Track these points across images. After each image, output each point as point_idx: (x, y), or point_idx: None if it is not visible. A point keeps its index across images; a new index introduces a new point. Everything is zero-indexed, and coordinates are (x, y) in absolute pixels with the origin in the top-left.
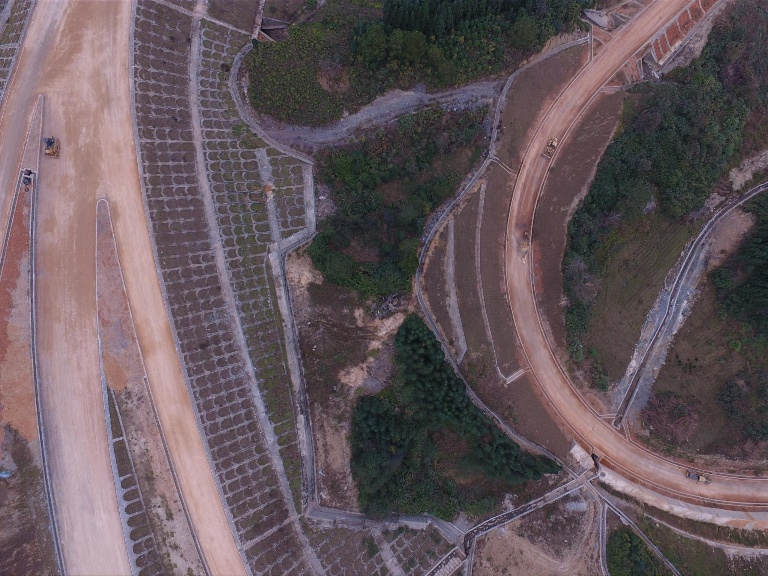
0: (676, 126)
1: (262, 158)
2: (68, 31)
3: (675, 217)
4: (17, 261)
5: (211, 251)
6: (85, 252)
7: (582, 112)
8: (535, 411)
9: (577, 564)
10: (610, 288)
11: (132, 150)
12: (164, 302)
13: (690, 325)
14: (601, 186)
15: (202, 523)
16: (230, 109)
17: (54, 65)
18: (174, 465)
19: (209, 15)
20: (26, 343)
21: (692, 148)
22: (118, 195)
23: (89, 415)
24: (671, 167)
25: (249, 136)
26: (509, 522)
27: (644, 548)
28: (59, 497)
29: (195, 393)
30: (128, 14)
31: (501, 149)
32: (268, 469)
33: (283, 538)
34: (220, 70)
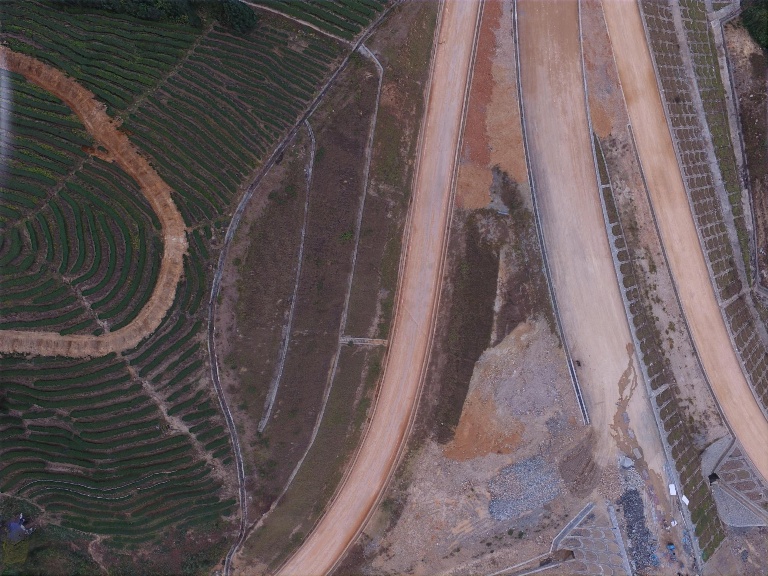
0: None
1: None
2: None
3: None
4: None
5: (669, 8)
6: None
7: None
8: None
9: None
10: None
11: None
12: (649, 47)
13: None
14: None
15: (682, 278)
16: None
17: None
18: (656, 217)
19: None
20: (512, 84)
21: None
22: None
23: (576, 160)
24: None
25: None
26: None
27: None
28: (549, 241)
29: (678, 144)
30: None
31: None
32: (726, 237)
33: (742, 307)
34: None
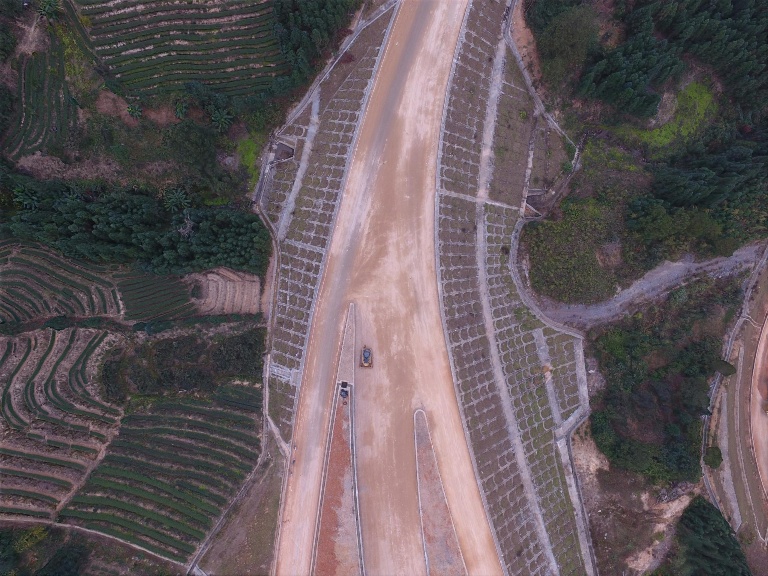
0: None
1: (539, 338)
2: (373, 234)
3: None
4: (340, 478)
5: (512, 448)
6: (405, 465)
7: None
8: None
9: None
10: None
11: (444, 357)
12: (486, 515)
13: None
14: None
15: None
16: (512, 293)
17: (362, 270)
18: None
19: (490, 199)
20: (354, 563)
21: None
22: (433, 404)
23: None
24: None
25: (529, 319)
26: None
27: None
28: None
29: None
30: (431, 214)
31: (754, 308)
32: None
33: None
34: (501, 253)
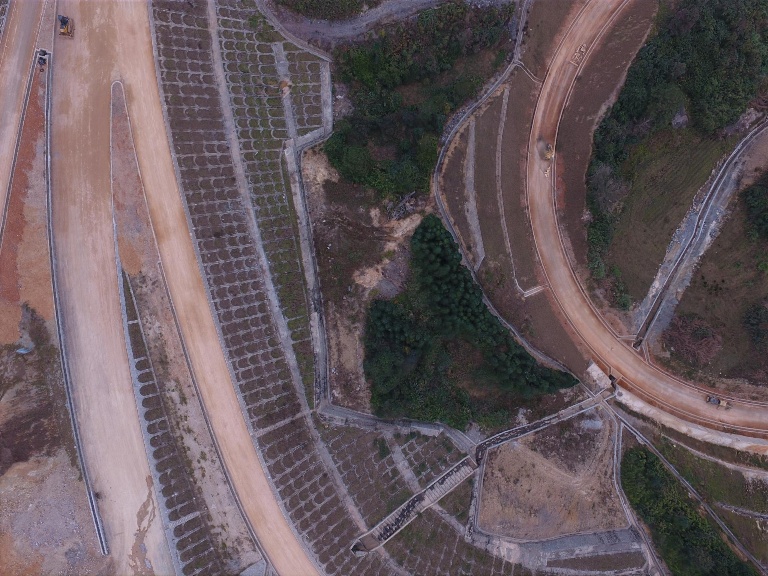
0: (714, 29)
1: (279, 52)
2: None
3: (708, 131)
4: (33, 142)
5: (226, 142)
6: (100, 135)
7: (613, 17)
8: (552, 328)
9: (590, 479)
10: (635, 205)
11: (147, 32)
12: (179, 187)
13: (718, 246)
14: (631, 91)
15: (215, 409)
16: None
17: None
18: (188, 350)
19: None
20: (42, 224)
21: (730, 56)
22: (133, 78)
23: (104, 297)
24: (706, 75)
25: (266, 28)
26: (522, 436)
27: (660, 465)
28: (75, 376)
29: (209, 280)
30: None
31: (526, 53)
32: (281, 362)
33: (295, 430)
34: None
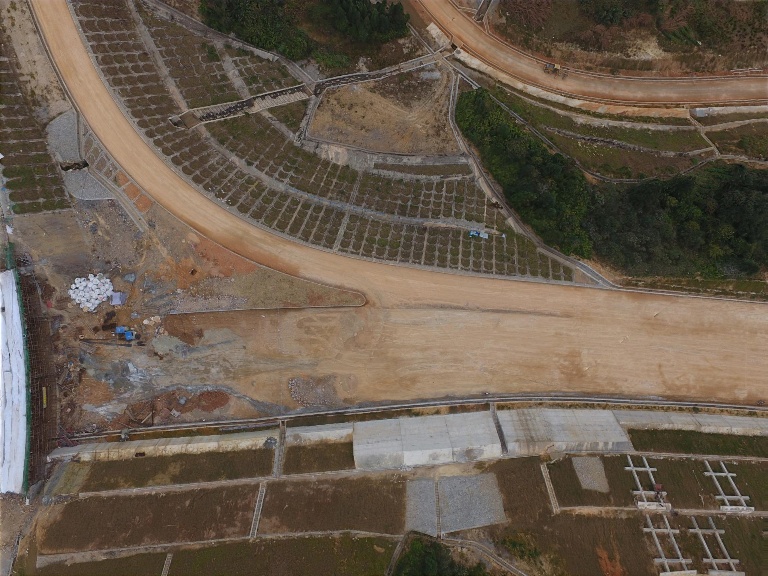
0: None
1: None
2: None
3: None
4: None
5: None
6: None
7: None
8: None
9: (425, 114)
10: None
11: None
12: None
13: None
14: None
15: None
16: None
17: None
18: None
19: None
20: None
21: None
22: None
23: None
24: None
25: None
26: (362, 82)
27: (489, 96)
28: None
29: None
30: None
31: None
32: None
33: (114, 5)
34: None
